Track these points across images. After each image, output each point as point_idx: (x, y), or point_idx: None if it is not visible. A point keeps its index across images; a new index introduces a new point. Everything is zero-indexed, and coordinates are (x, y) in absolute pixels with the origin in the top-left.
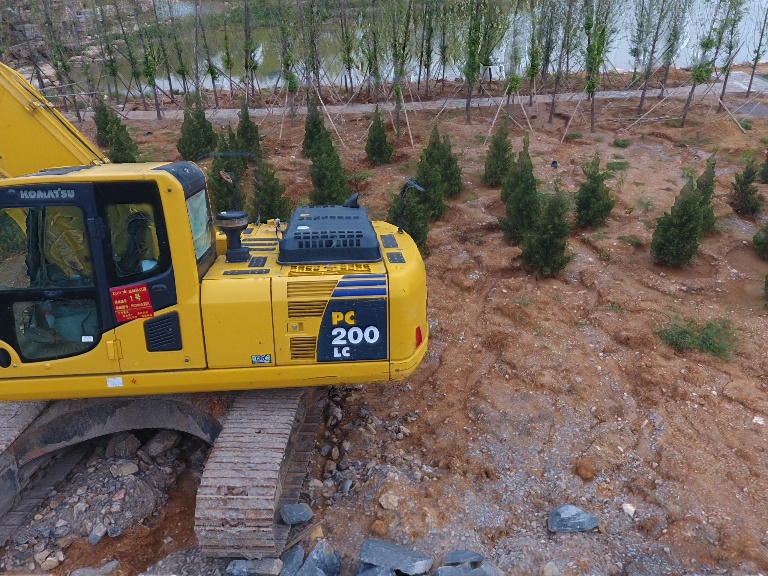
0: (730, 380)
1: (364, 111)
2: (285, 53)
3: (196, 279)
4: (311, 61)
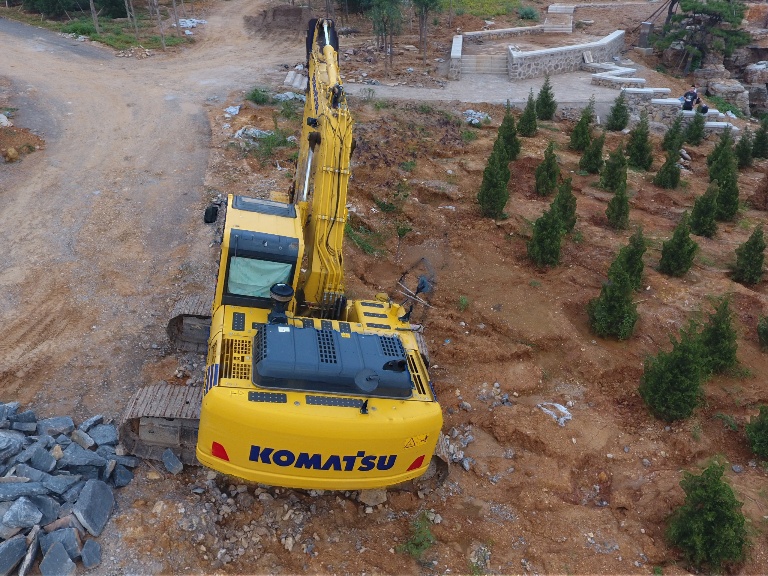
0: None
1: None
2: None
3: (218, 300)
4: None
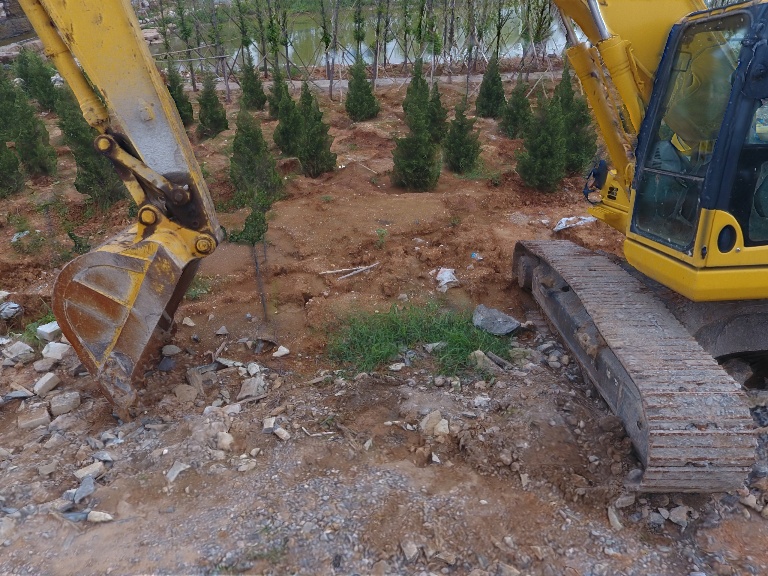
0: None
1: None
2: (430, 13)
3: None
4: (420, 31)
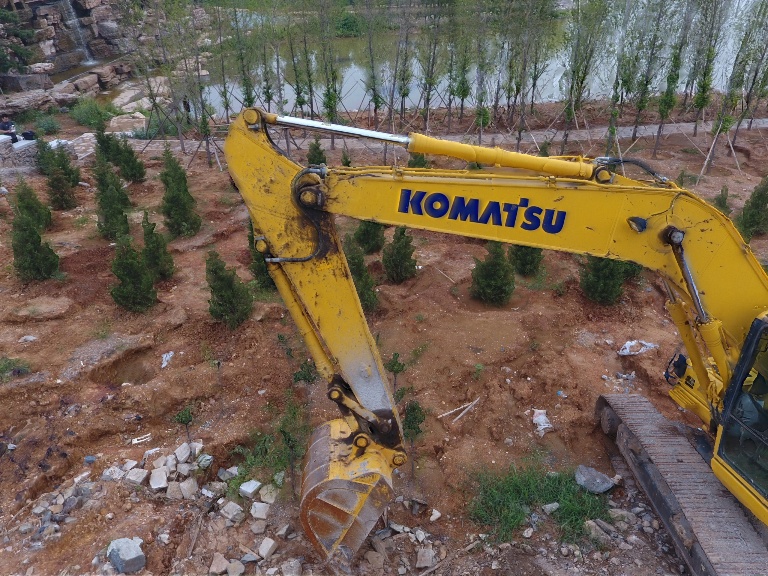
0: None
1: (531, 141)
2: (480, 89)
3: None
4: (461, 87)
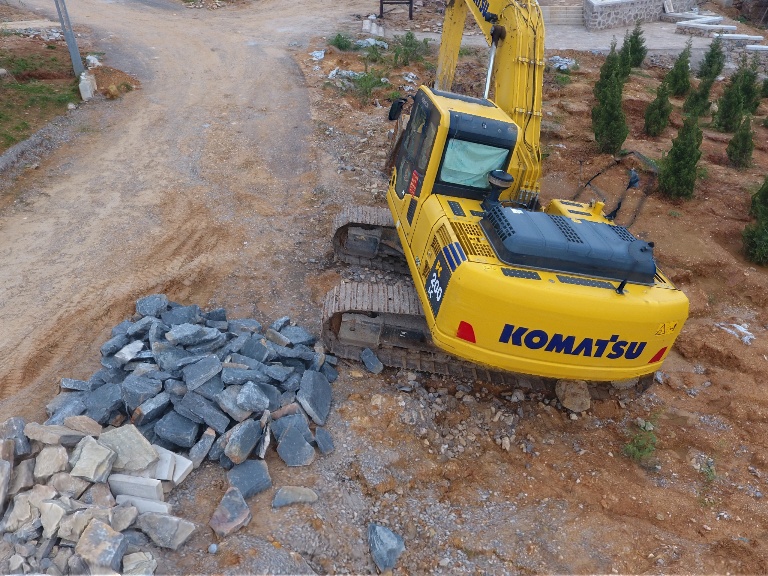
0: None
1: None
2: None
3: (429, 189)
4: None
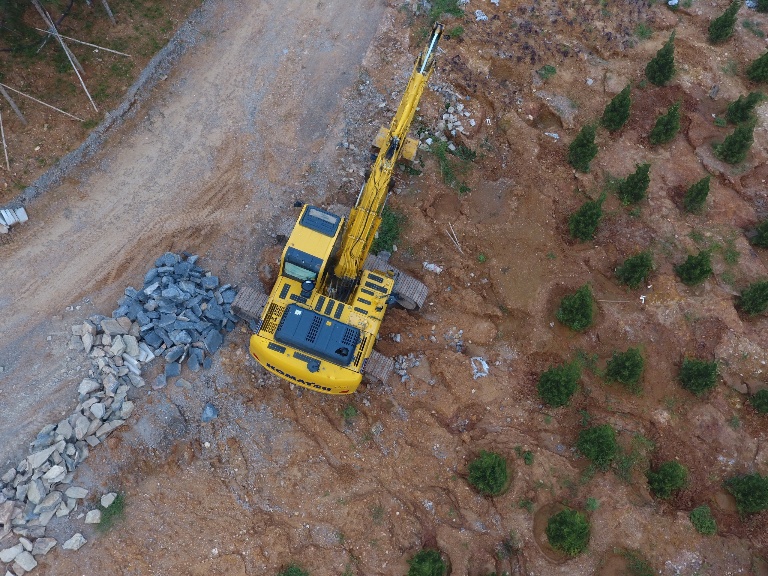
0: (248, 573)
1: None
2: None
3: None
4: None
